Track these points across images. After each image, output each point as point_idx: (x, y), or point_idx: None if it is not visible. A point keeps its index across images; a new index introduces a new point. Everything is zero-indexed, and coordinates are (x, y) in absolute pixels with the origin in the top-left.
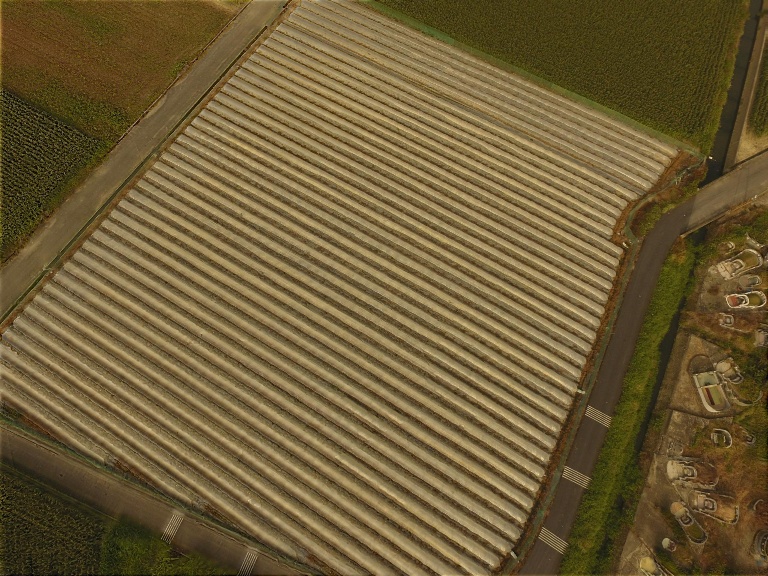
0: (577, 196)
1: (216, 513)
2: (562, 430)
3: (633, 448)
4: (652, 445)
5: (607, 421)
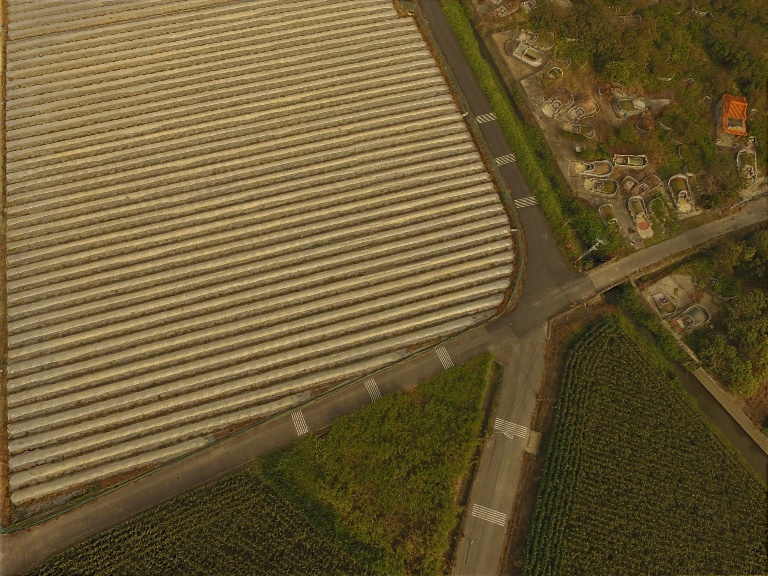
0: (355, 7)
1: (319, 385)
2: (475, 144)
3: (519, 122)
4: (527, 110)
5: (493, 116)
